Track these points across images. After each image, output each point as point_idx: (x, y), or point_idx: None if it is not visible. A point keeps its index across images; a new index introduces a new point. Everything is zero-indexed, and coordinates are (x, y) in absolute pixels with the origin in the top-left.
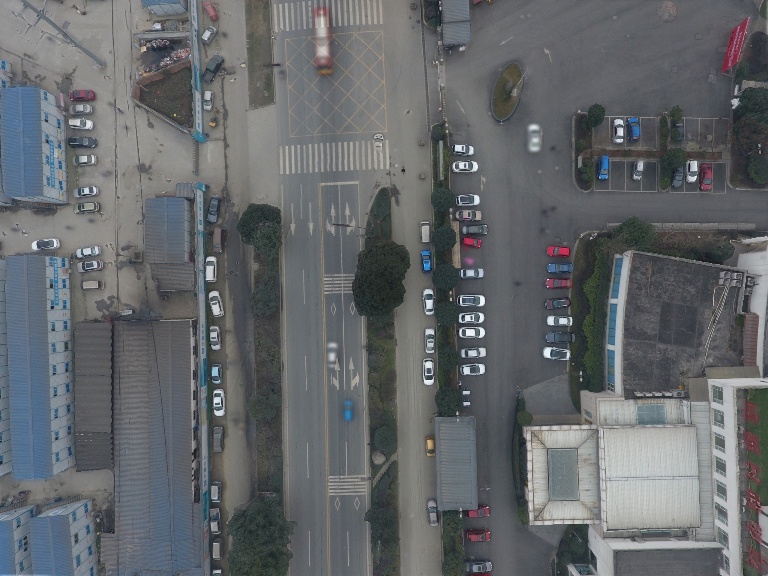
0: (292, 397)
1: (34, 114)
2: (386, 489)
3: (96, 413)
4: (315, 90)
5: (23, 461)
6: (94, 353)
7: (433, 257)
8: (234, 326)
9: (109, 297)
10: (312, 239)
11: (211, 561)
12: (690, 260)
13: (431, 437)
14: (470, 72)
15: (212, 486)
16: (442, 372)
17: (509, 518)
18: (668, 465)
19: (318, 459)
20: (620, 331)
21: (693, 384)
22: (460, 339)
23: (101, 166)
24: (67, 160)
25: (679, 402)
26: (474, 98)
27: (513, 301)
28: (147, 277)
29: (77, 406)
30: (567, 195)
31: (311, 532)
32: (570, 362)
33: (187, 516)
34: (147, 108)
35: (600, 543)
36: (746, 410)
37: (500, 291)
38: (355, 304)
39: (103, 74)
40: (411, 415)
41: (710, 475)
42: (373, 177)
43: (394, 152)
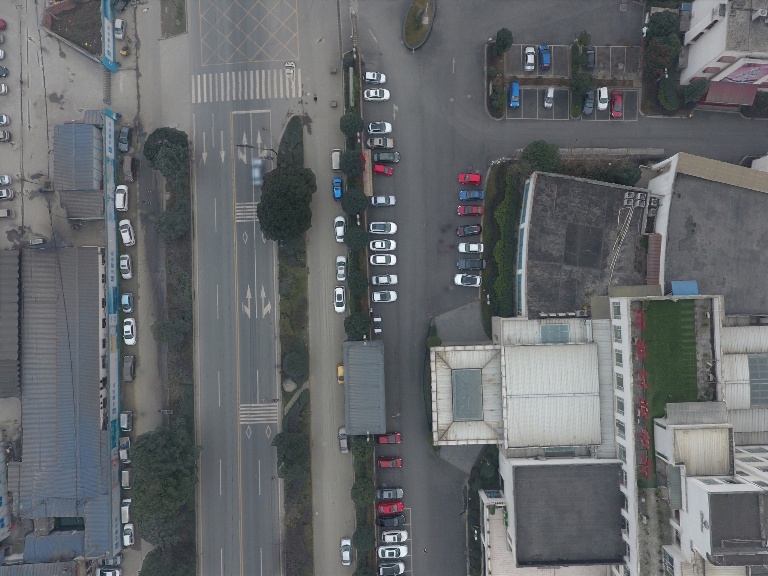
0: (203, 326)
1: None
2: (297, 416)
3: (3, 340)
4: (227, 19)
5: None
6: (1, 280)
7: (345, 185)
8: (146, 255)
9: (20, 227)
10: (224, 167)
11: (121, 491)
12: (594, 180)
13: (342, 364)
14: (383, 1)
15: (121, 414)
16: (353, 299)
17: (421, 445)
18: (569, 382)
19: (229, 387)
20: (524, 252)
21: (595, 302)
22: (372, 267)
23: (12, 96)
24: None
25: (583, 322)
26: (387, 27)
27: (425, 229)
28: (58, 207)
29: None
30: (479, 123)
31: (222, 461)
32: (482, 289)
33: (94, 443)
34: (57, 36)
35: (505, 464)
36: (642, 323)
37: (412, 219)
38: (260, 227)
39: (15, 4)
40: (323, 343)
41: (611, 392)
42: (285, 105)
43: (306, 80)
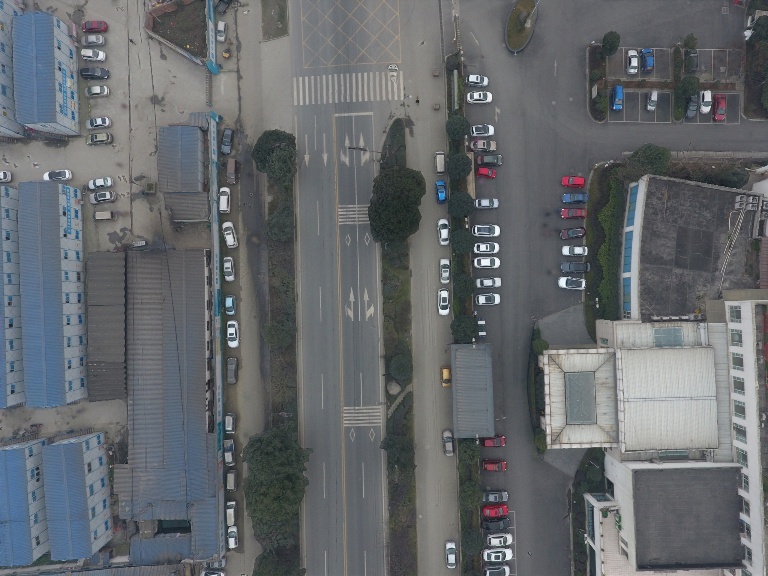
0: (306, 328)
1: (47, 40)
2: (401, 419)
3: (109, 343)
4: (329, 21)
5: (36, 388)
6: (107, 282)
7: (448, 188)
8: (248, 258)
9: (121, 229)
10: (326, 170)
11: (225, 493)
12: (706, 184)
13: (446, 367)
14: (484, 4)
15: (226, 416)
16: (457, 302)
17: (525, 448)
18: (686, 386)
19: (333, 390)
20: (636, 255)
21: (710, 306)
22: (475, 269)
23: (113, 98)
24: (79, 92)
25: (696, 325)
26: (488, 30)
27: (528, 232)
28: None
29: (90, 336)
30: (581, 126)
31: (326, 463)
32: (585, 292)
33: (201, 446)
34: (160, 38)
35: (617, 467)
36: (764, 326)
37: (515, 222)
38: (371, 229)
39: (115, 6)
40: (426, 346)
41: (728, 396)
42: (387, 108)
43: (408, 83)
